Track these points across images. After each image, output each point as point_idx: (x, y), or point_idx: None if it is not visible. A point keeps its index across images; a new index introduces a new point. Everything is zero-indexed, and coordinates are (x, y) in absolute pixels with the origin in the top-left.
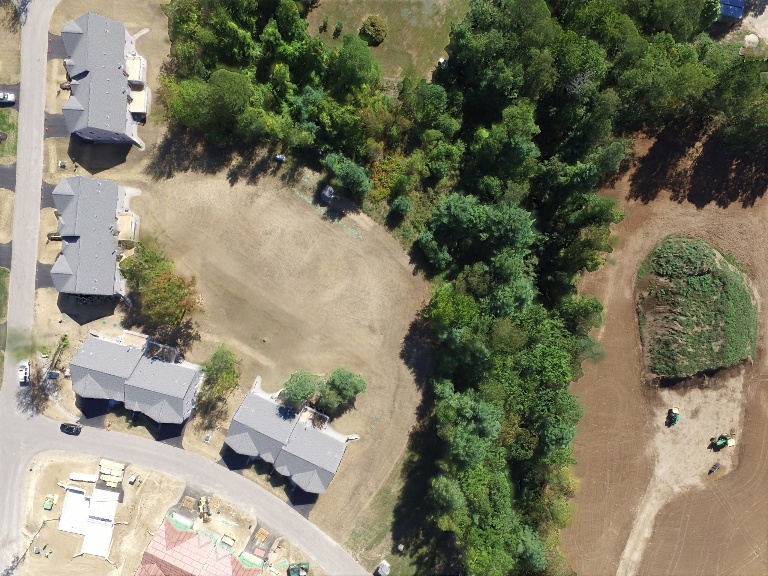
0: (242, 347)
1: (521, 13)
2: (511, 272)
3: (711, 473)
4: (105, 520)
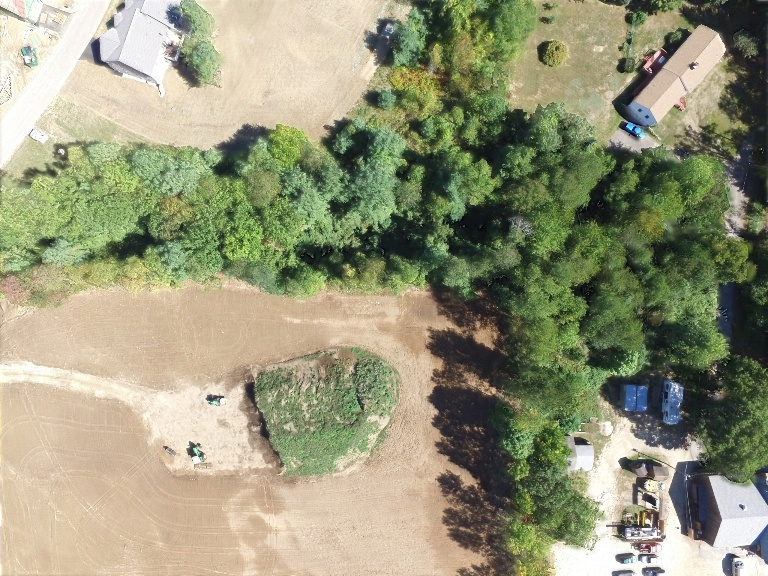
0: None
1: (581, 160)
2: (326, 183)
3: (165, 449)
4: None
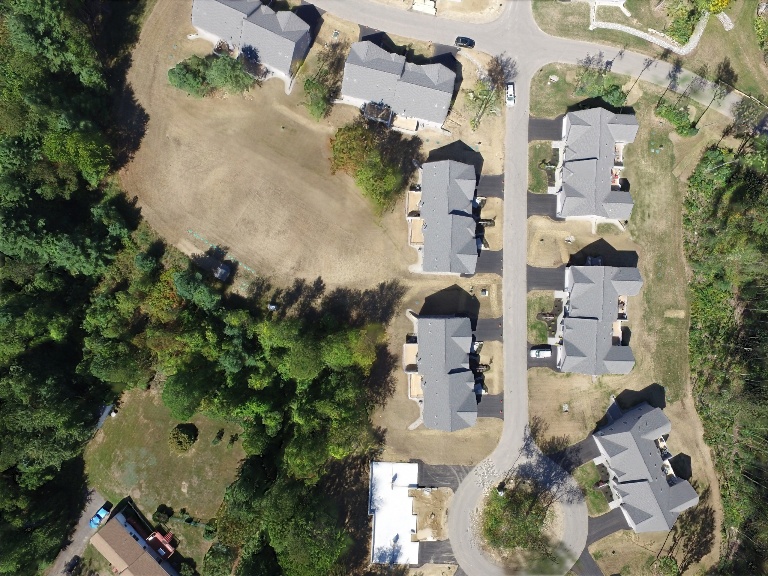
0: (306, 122)
1: None
2: None
3: None
4: None
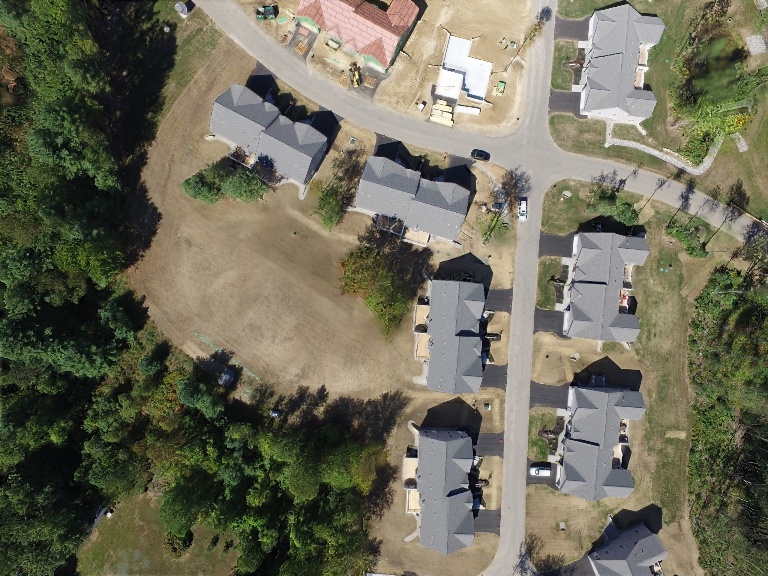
0: (318, 228)
1: None
2: None
3: None
4: (451, 70)
